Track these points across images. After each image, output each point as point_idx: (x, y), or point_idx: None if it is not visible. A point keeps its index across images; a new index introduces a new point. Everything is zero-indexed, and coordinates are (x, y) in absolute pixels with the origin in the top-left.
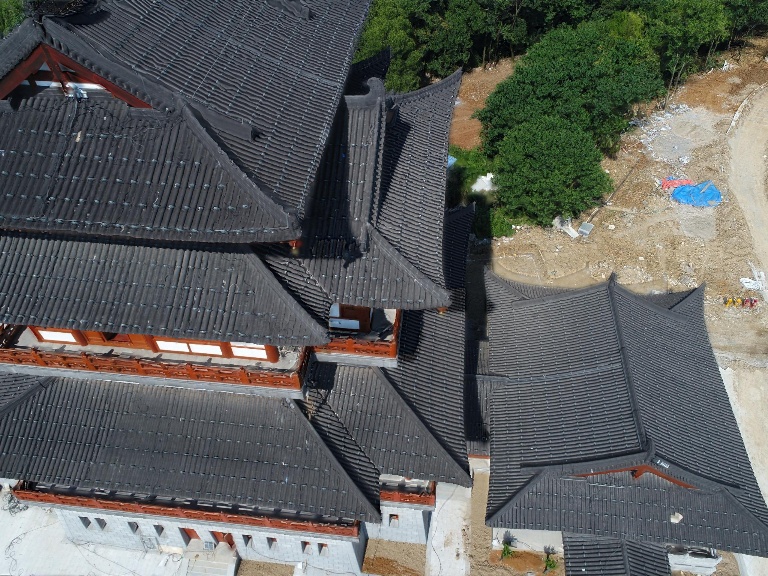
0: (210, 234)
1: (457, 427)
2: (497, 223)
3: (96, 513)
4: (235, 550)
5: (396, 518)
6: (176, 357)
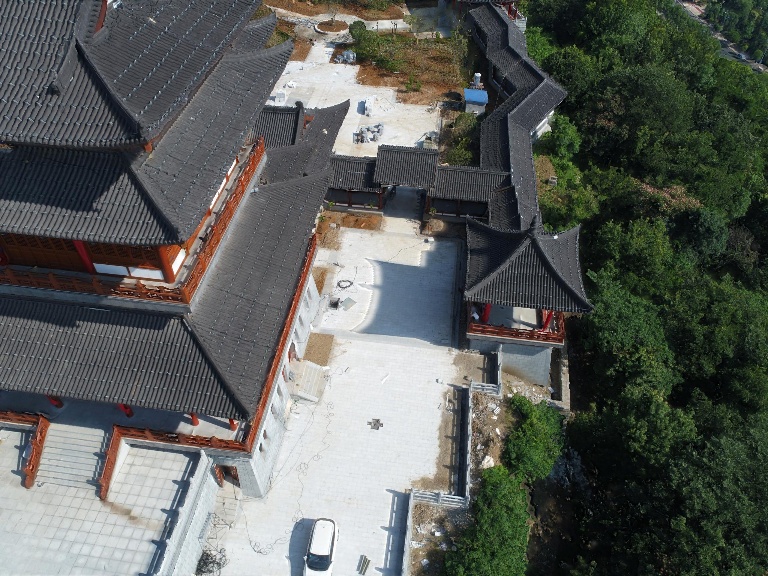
0: (252, 8)
1: None
2: None
3: None
4: (297, 361)
5: None
6: (219, 205)
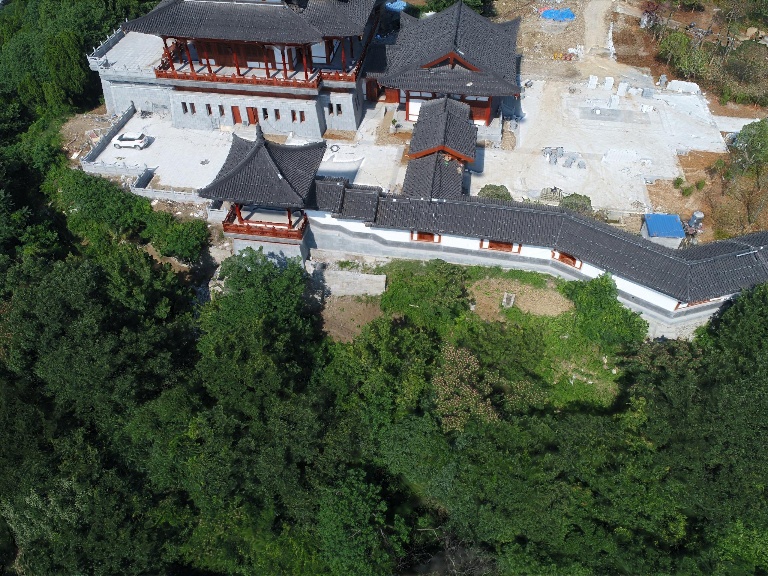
0: None
1: (362, 24)
2: None
3: (191, 96)
4: None
5: (341, 114)
6: None
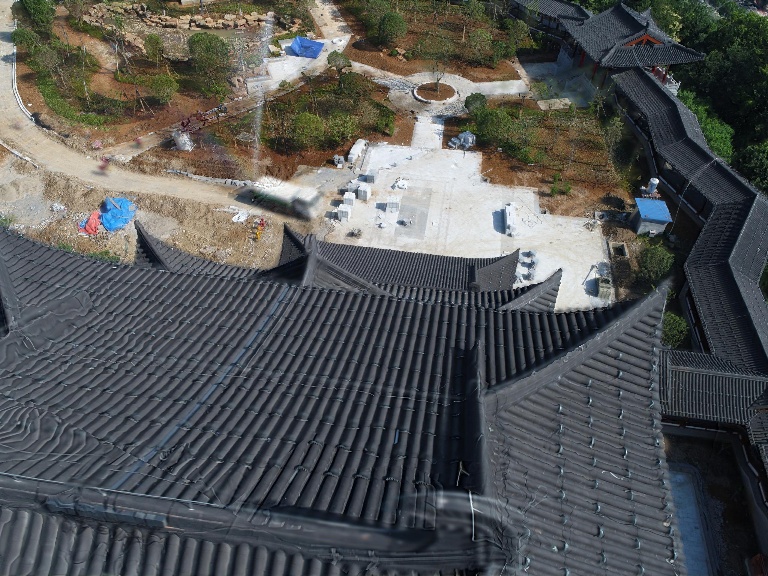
0: None
1: None
2: None
3: None
4: None
5: None
6: None
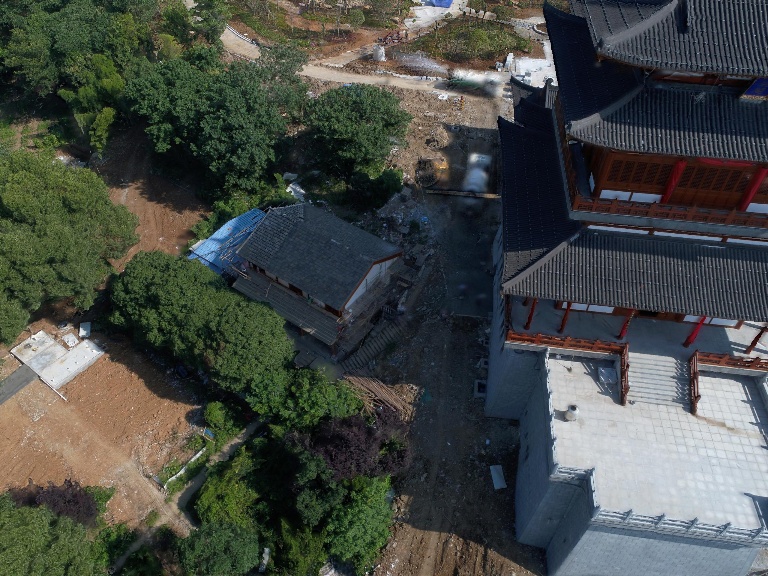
0: None
1: None
2: (396, 172)
3: None
4: None
5: None
6: None
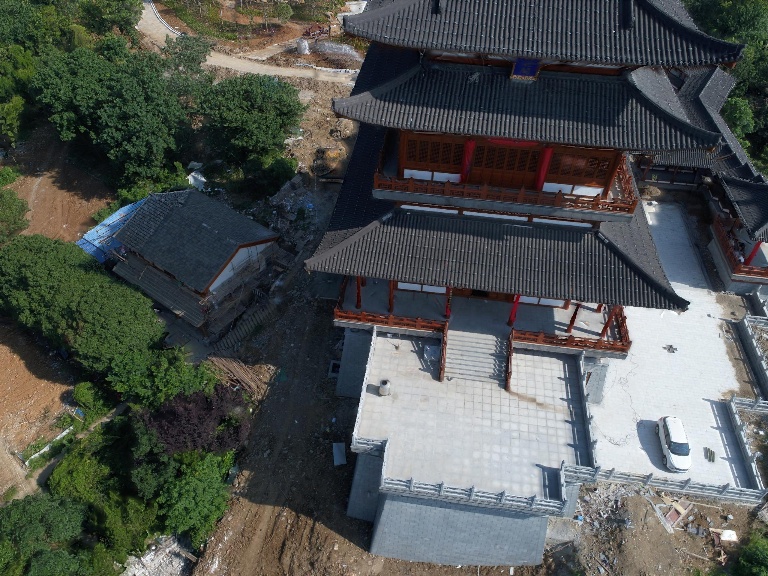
0: None
1: None
2: (289, 161)
3: None
4: None
5: None
6: None
